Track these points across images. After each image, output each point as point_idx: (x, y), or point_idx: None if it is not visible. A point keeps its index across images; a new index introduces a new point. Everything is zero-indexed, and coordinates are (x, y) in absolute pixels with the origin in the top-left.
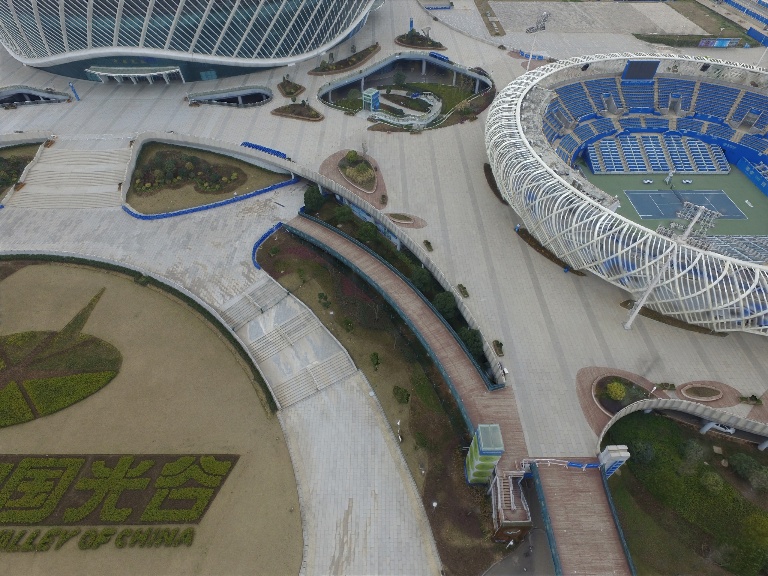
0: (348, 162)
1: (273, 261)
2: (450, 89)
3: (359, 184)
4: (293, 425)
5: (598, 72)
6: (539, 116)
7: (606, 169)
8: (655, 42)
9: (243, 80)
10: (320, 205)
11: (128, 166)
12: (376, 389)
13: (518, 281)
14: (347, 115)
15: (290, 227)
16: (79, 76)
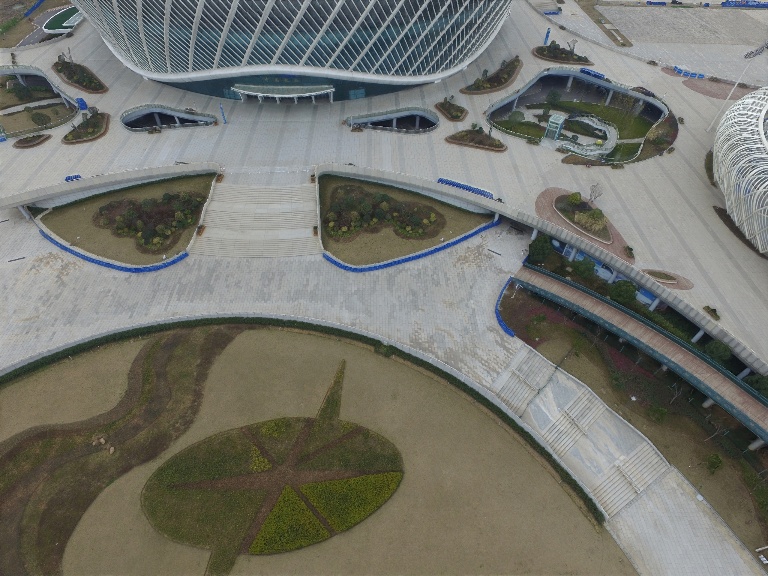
0: (570, 205)
1: (524, 326)
2: (616, 111)
3: (593, 232)
4: (630, 541)
5: None
6: None
7: None
8: None
9: (394, 99)
10: (548, 255)
11: (318, 206)
12: (702, 491)
13: None
14: (530, 144)
15: (525, 283)
16: (213, 93)
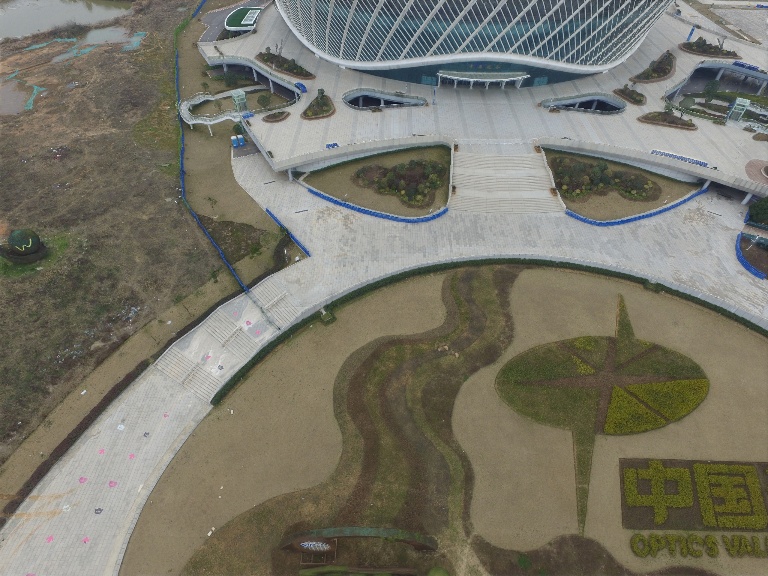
0: None
1: None
2: None
3: None
4: None
5: None
6: None
7: None
8: None
9: (573, 86)
10: None
11: (551, 172)
12: None
13: None
14: (717, 124)
15: (758, 237)
16: (411, 80)
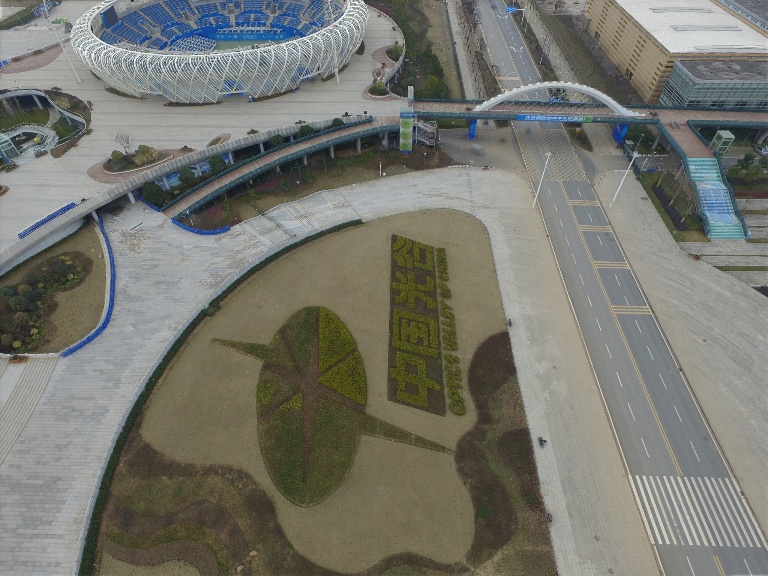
0: (121, 162)
1: (223, 221)
2: (4, 117)
3: (157, 160)
4: (373, 215)
5: None
6: None
7: None
8: (9, 28)
9: None
10: None
11: None
12: (351, 183)
13: (297, 106)
14: (12, 170)
15: (183, 212)
16: None
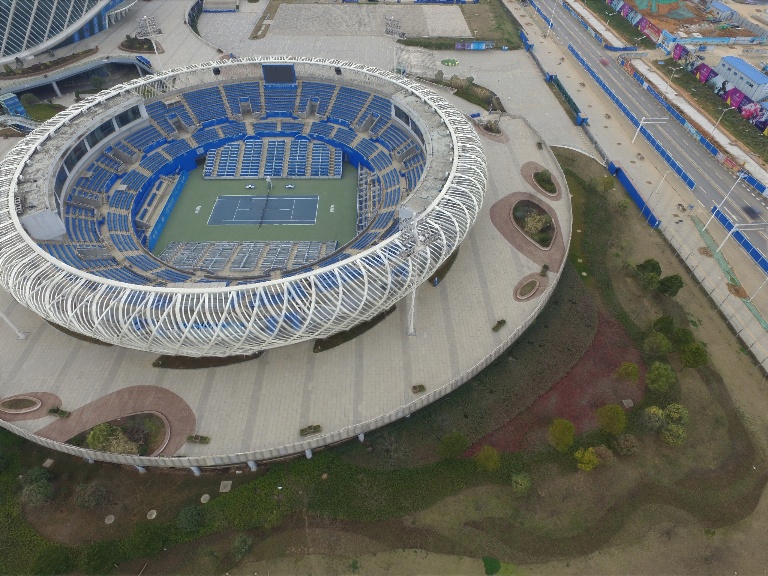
0: None
1: None
2: None
3: None
4: None
5: (251, 76)
6: (91, 121)
7: (216, 174)
8: (412, 45)
9: None
10: None
11: None
12: None
13: None
14: None
15: None
16: None
